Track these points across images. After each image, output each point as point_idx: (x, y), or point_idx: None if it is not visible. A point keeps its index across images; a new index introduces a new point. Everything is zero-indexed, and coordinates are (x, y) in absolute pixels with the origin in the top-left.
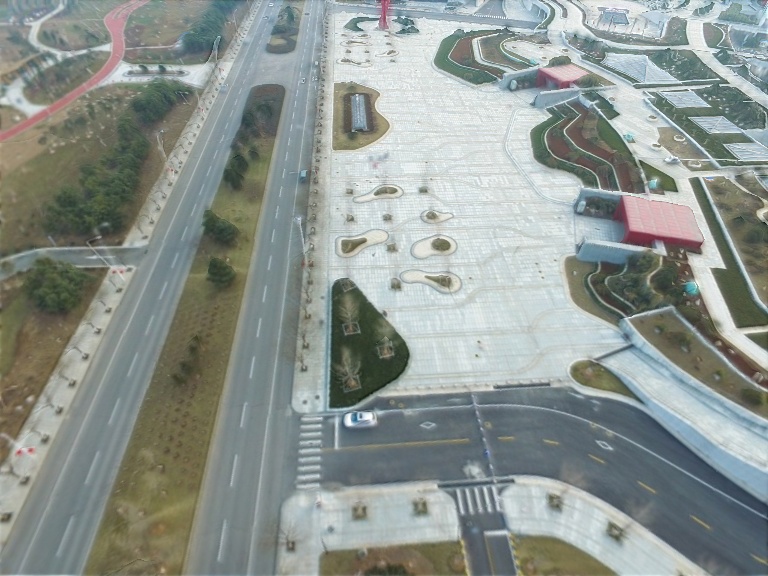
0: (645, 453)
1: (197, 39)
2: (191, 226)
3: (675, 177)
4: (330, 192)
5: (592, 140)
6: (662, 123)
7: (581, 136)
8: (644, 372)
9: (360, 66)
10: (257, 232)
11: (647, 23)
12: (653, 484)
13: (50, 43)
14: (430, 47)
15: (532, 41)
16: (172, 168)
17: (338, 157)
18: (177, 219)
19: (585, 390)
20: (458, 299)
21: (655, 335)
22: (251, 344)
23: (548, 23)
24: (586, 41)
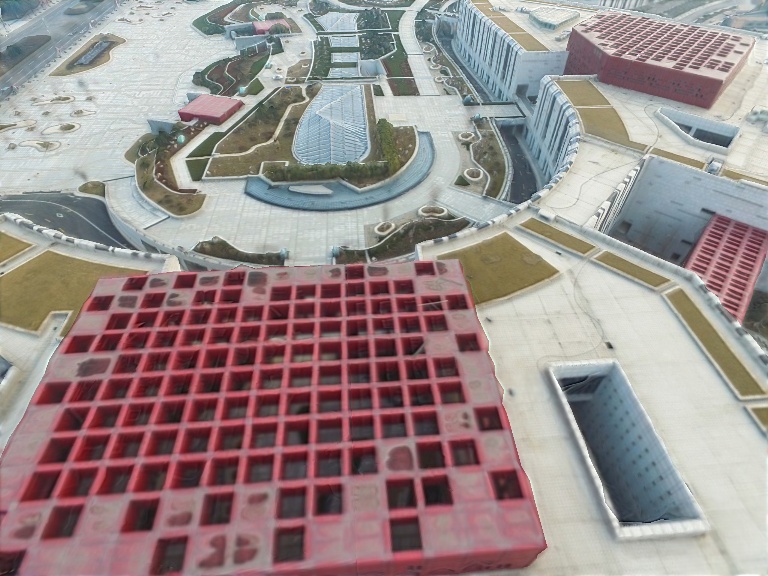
0: (80, 218)
1: None
2: None
3: (267, 87)
4: (19, 100)
5: (235, 66)
6: (308, 57)
7: None
8: (123, 185)
9: (131, 23)
10: None
11: None
12: (67, 229)
13: None
14: (206, 11)
15: (283, 4)
16: None
17: (47, 80)
18: None
19: (79, 194)
20: (48, 154)
21: None
22: None
23: None
24: None
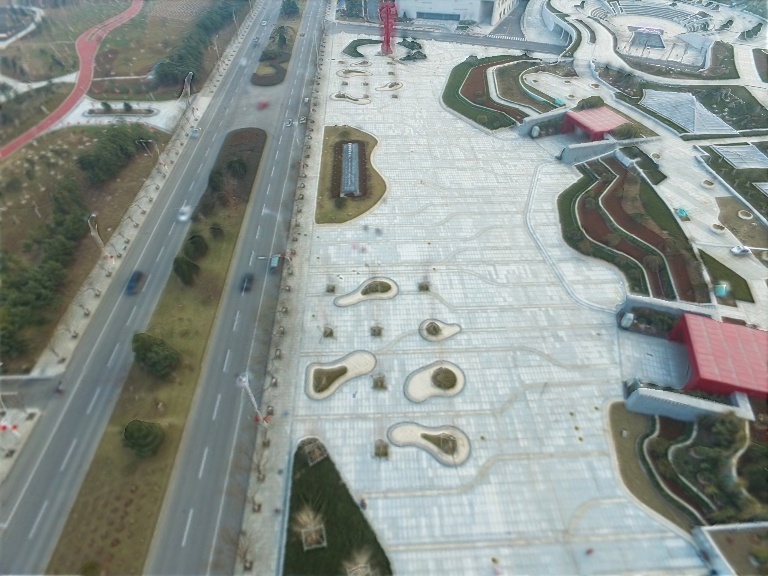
0: None
1: (171, 70)
2: (124, 343)
3: (747, 277)
4: (306, 289)
5: (636, 218)
6: (721, 191)
7: (621, 209)
8: None
9: (357, 103)
10: (206, 354)
11: (687, 49)
12: None
13: (9, 72)
14: (438, 78)
15: (556, 73)
16: (113, 252)
17: (321, 234)
18: (108, 330)
19: None
20: (465, 476)
21: (751, 569)
22: (172, 561)
23: (574, 50)
24: (619, 74)
